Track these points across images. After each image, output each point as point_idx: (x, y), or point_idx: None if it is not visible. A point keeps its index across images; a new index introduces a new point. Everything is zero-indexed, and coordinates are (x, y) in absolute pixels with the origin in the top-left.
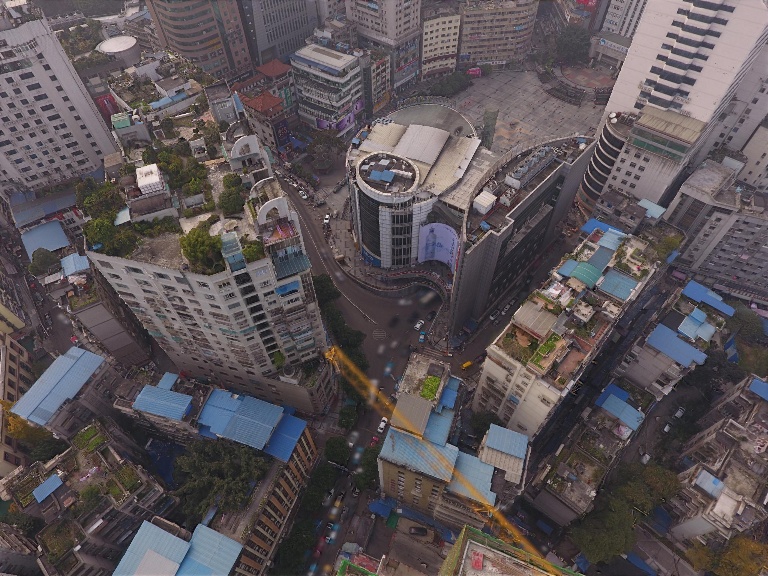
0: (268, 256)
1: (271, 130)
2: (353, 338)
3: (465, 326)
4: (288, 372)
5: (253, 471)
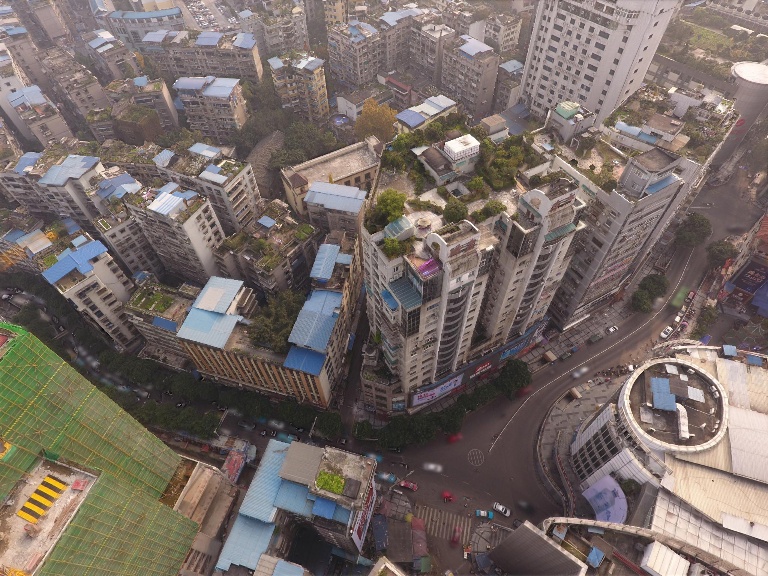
0: (390, 261)
1: (744, 261)
2: (445, 418)
3: (508, 575)
4: (369, 349)
5: (275, 341)
